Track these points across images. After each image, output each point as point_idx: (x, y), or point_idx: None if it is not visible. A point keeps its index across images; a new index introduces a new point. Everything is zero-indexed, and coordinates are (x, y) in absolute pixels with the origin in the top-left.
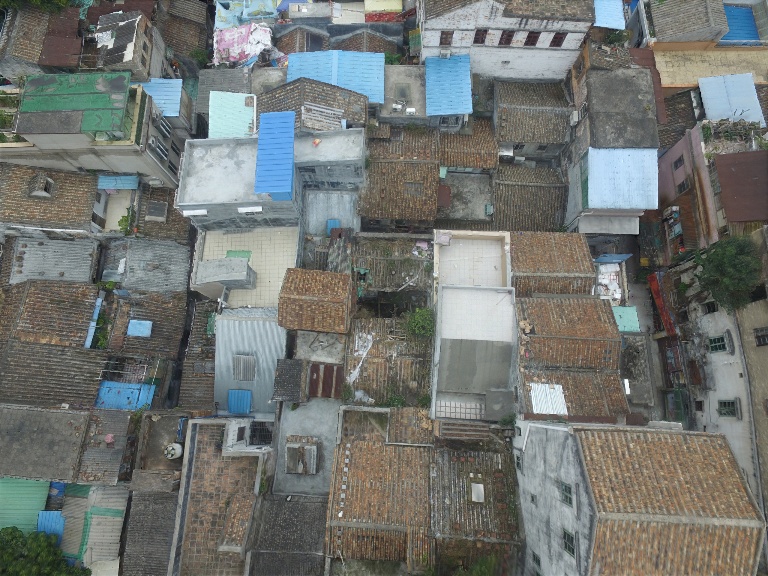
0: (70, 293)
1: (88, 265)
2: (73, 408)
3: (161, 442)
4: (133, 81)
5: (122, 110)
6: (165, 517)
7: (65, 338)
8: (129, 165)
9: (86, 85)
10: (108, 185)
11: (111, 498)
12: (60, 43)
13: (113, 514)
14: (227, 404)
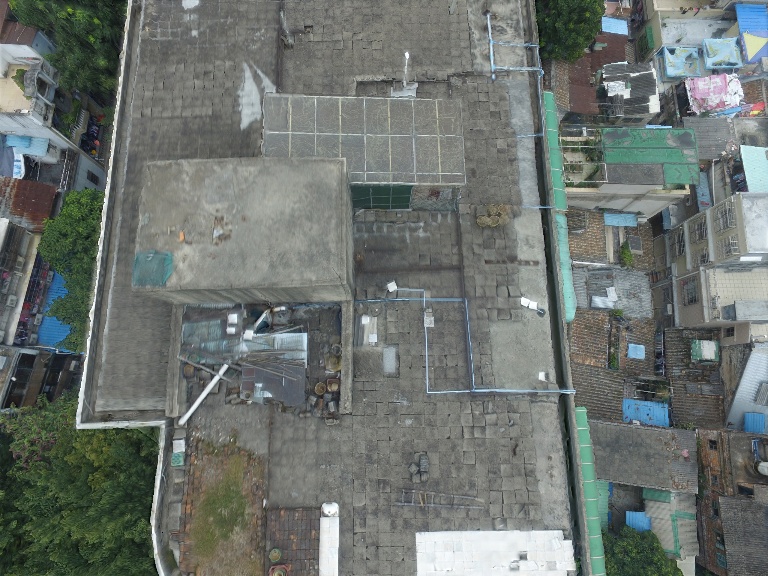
0: (595, 320)
1: (585, 292)
2: (641, 424)
3: (736, 459)
4: (631, 127)
5: (697, 165)
6: (757, 524)
7: (597, 360)
8: (644, 206)
9: (658, 140)
10: (613, 222)
11: (685, 503)
12: (580, 91)
13: (689, 517)
14: (738, 424)
